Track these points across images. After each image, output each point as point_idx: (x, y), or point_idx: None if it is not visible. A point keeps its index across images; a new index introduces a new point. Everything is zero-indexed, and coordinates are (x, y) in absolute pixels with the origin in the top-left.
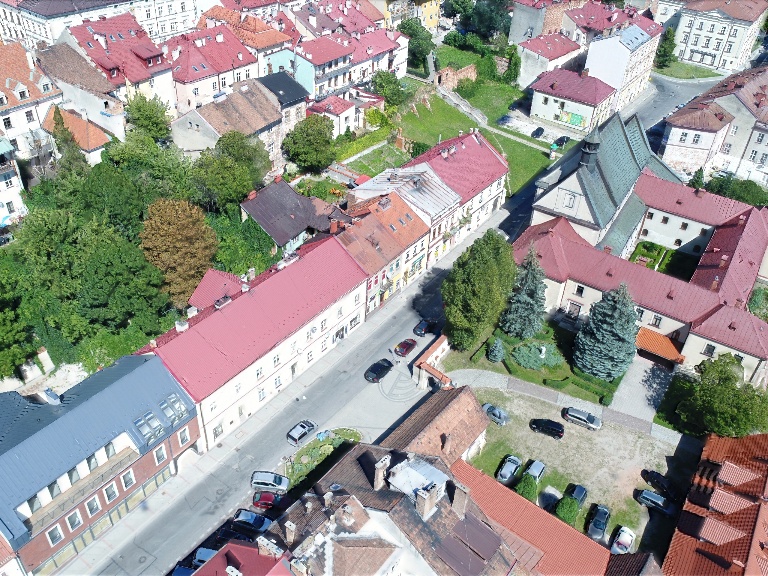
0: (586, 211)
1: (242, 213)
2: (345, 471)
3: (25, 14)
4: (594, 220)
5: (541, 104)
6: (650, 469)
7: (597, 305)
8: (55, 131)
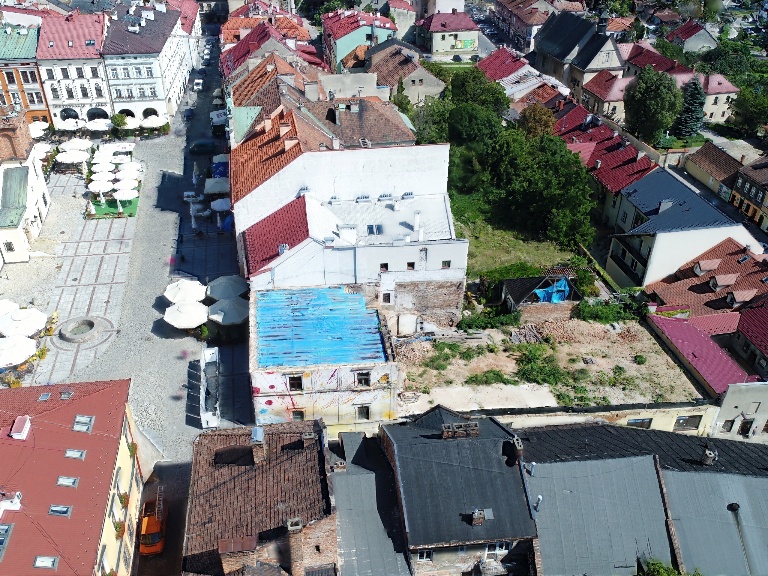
0: (616, 60)
1: (502, 123)
2: (763, 174)
3: (112, 62)
4: (621, 64)
5: (440, 41)
6: (759, 153)
7: (683, 94)
8: (400, 99)
